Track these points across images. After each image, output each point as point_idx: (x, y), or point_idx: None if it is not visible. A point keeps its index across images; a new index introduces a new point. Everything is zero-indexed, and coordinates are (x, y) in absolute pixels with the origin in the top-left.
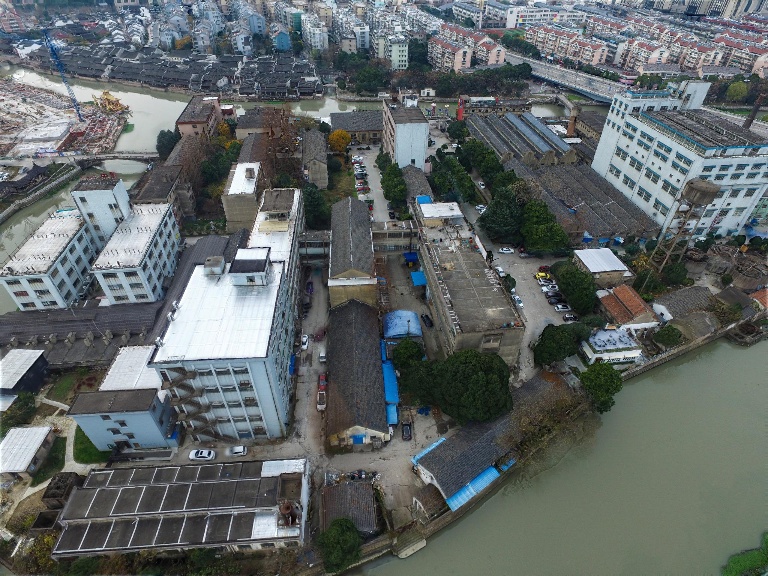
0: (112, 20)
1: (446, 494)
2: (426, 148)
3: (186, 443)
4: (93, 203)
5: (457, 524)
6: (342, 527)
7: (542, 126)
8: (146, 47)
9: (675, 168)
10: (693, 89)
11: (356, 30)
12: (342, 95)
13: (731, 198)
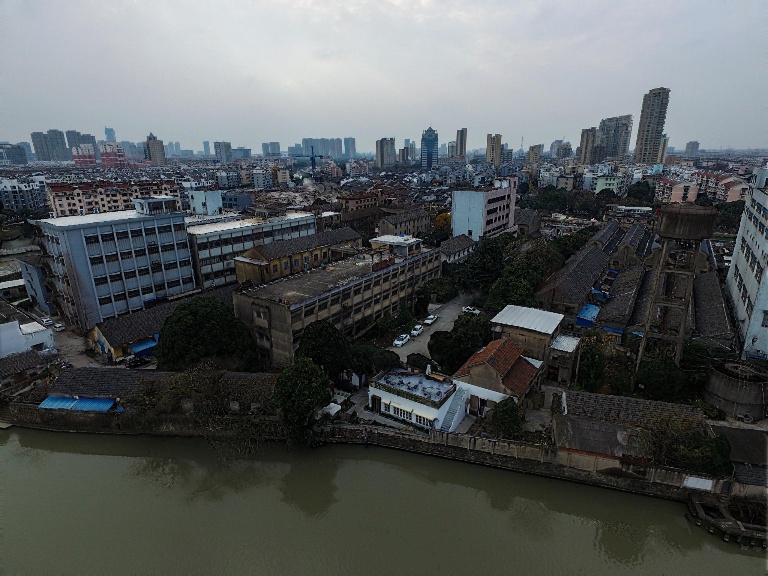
0: (416, 173)
1: (50, 389)
2: (484, 219)
3: (56, 316)
4: (196, 200)
5: (62, 451)
6: None
7: None
8: (408, 181)
9: (766, 238)
10: None
11: (588, 176)
12: None
13: None
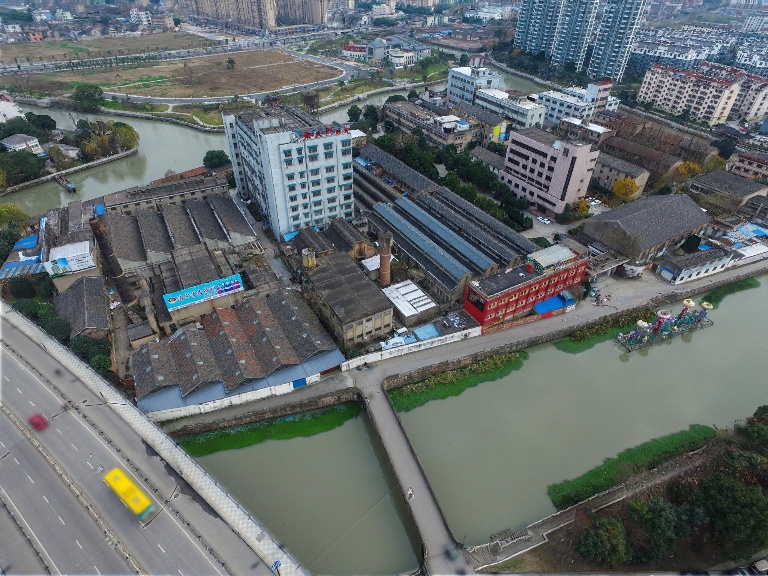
0: None
1: None
2: None
3: None
4: None
5: None
6: (414, 92)
7: (427, 239)
8: None
9: None
10: None
11: None
12: None
13: None
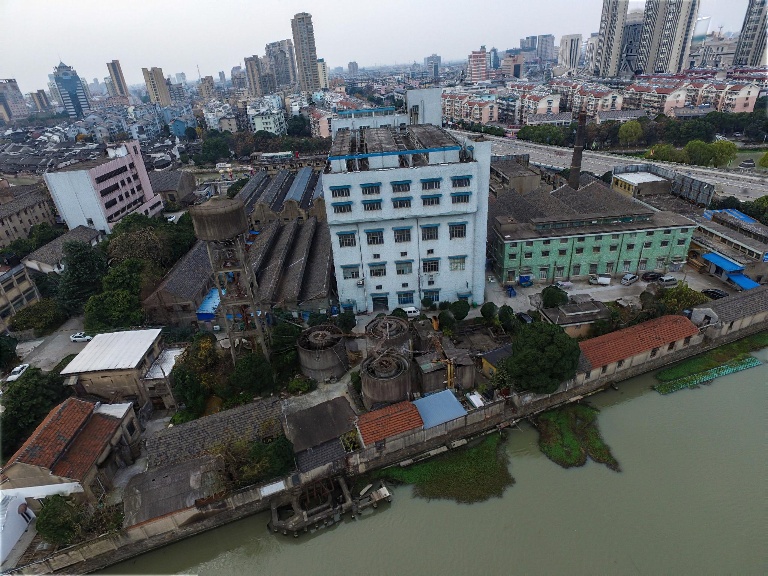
0: (59, 127)
1: None
2: (100, 203)
3: None
4: None
5: None
6: None
7: None
8: (41, 142)
9: None
10: (417, 98)
11: (252, 113)
12: (184, 169)
13: (428, 241)
